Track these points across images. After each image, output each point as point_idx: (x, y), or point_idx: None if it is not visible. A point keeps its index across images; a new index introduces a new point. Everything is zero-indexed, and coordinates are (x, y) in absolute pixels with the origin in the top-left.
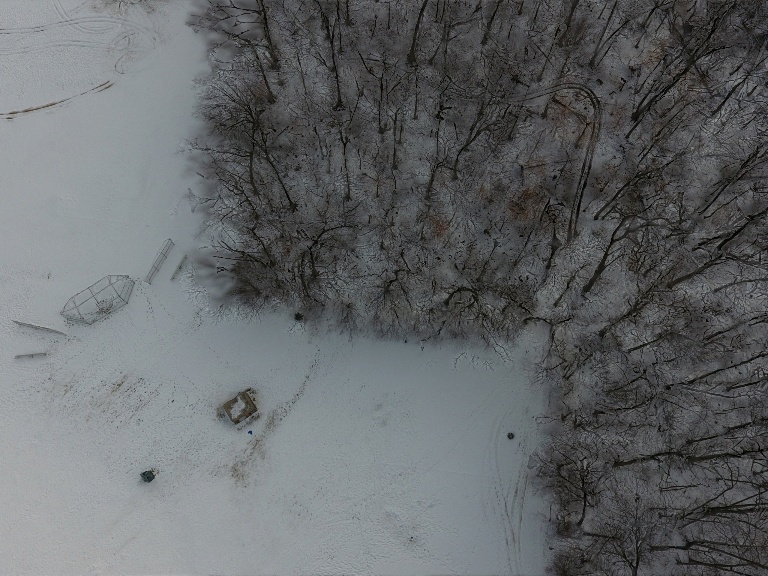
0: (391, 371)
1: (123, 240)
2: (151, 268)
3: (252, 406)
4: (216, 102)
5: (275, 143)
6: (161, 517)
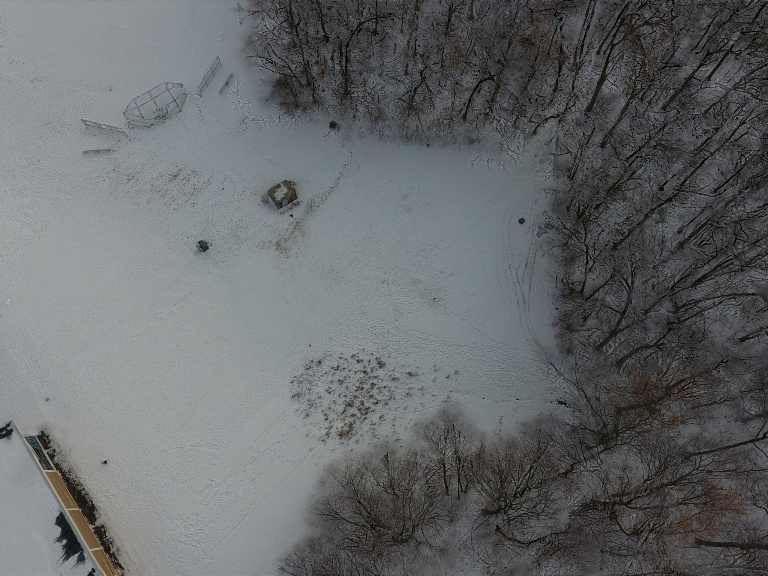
0: (415, 169)
1: (176, 61)
2: (202, 80)
3: (293, 191)
4: None
5: None
6: (215, 279)
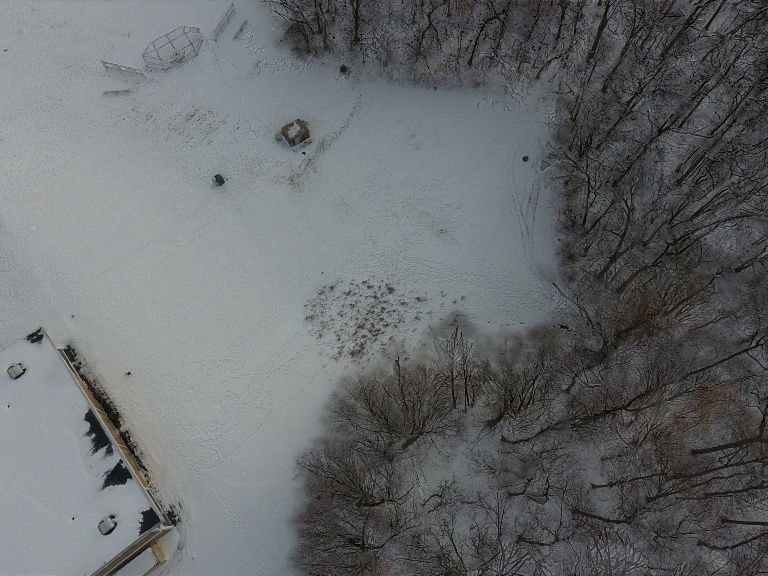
0: (423, 110)
1: (192, 9)
2: (218, 25)
3: (306, 129)
4: None
5: None
6: (231, 211)
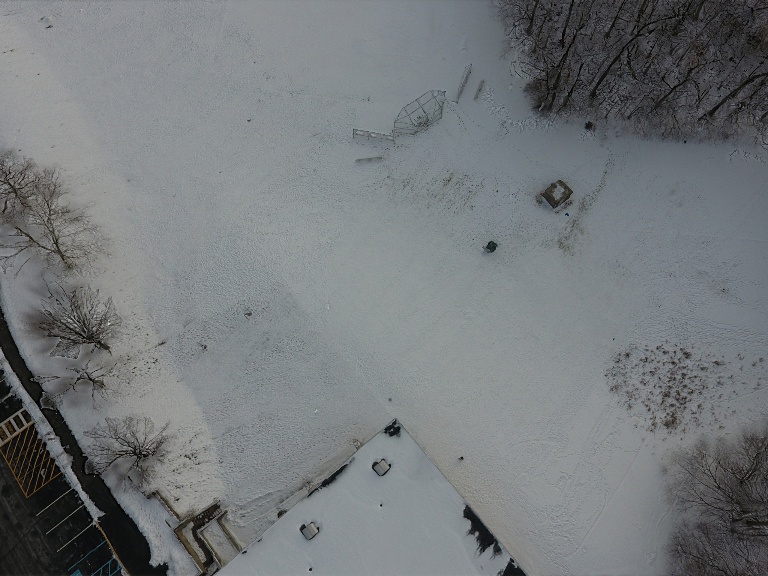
0: (677, 165)
1: (426, 70)
2: (461, 87)
3: (570, 190)
4: None
5: None
6: (508, 278)
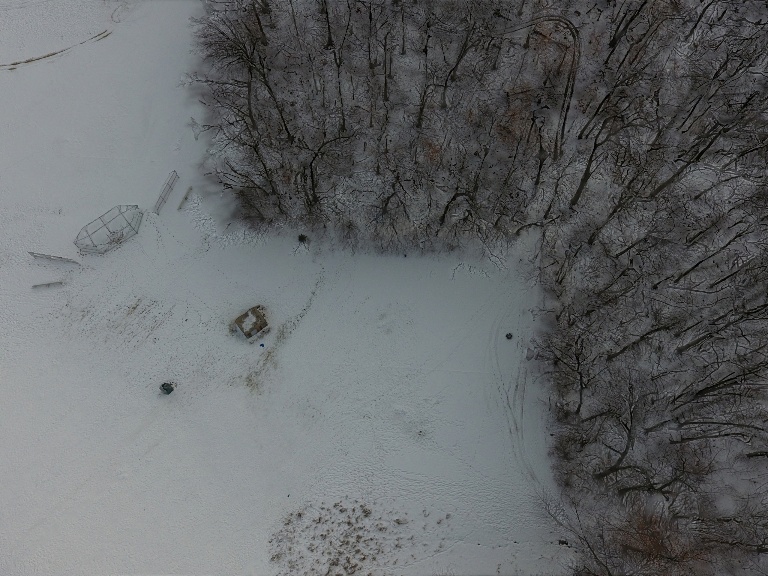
0: (393, 283)
1: (129, 176)
2: (158, 198)
3: (263, 319)
4: (212, 40)
5: (270, 81)
6: (182, 425)
